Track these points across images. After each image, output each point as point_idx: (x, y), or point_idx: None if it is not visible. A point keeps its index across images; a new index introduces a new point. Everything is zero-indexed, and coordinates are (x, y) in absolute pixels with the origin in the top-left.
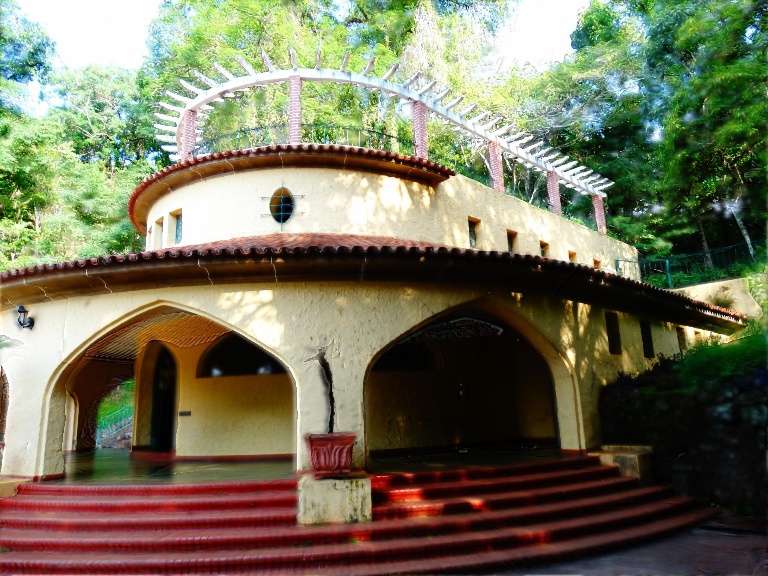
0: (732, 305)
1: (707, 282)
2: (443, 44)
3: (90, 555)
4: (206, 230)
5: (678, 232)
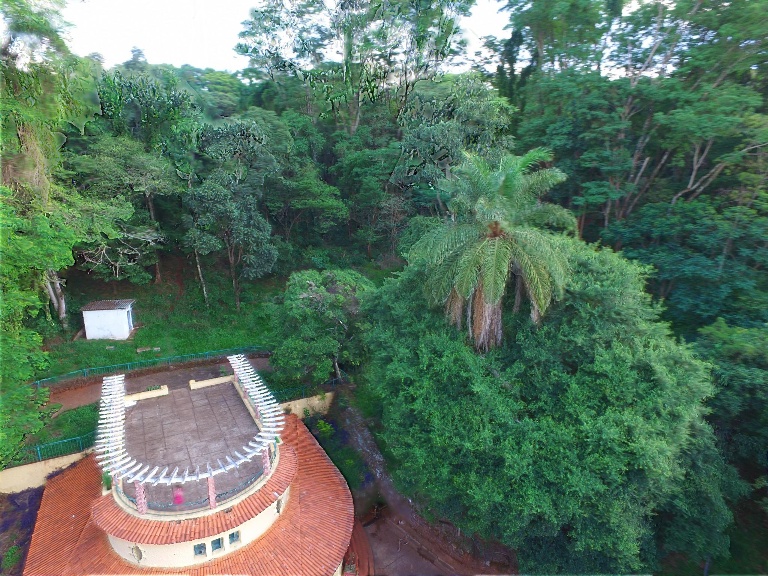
0: (291, 411)
1: (283, 402)
2: None
3: None
4: None
5: (150, 263)
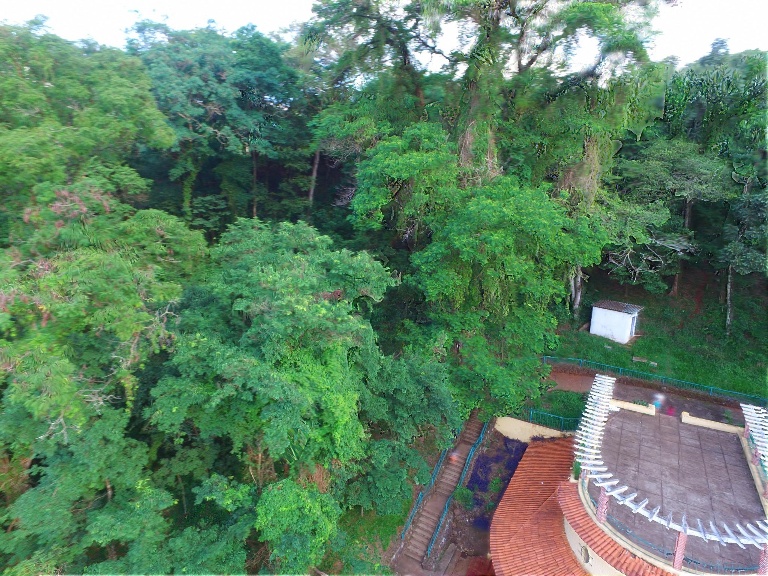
0: None
1: None
2: (597, 162)
3: None
4: None
5: (669, 273)
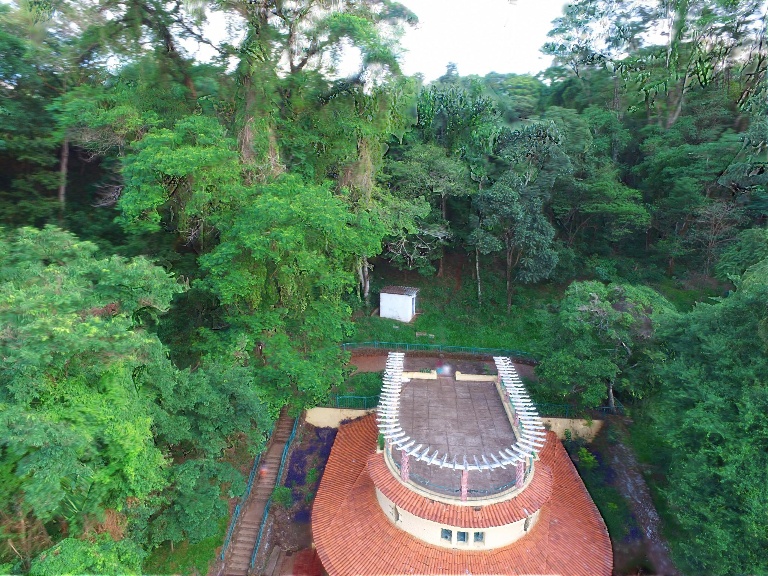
0: (551, 428)
1: (543, 416)
2: None
3: None
4: (500, 542)
5: (436, 257)
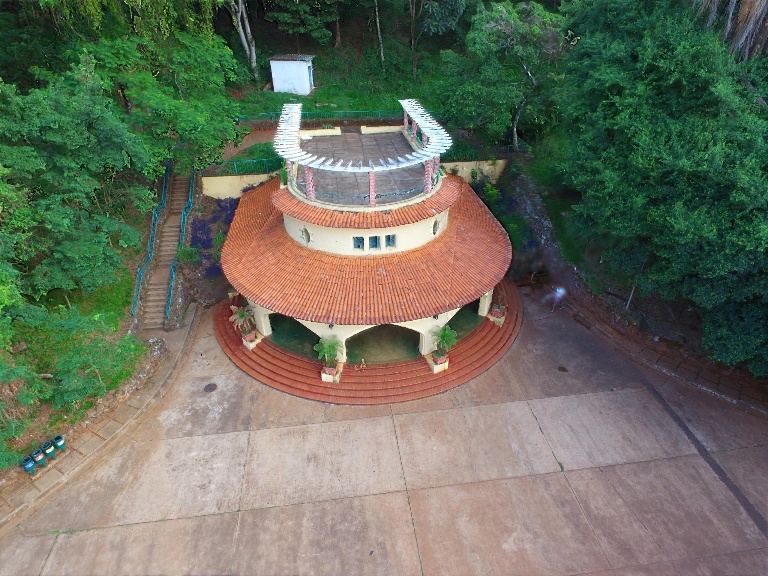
0: None
1: (450, 162)
2: None
3: (488, 354)
4: (410, 244)
5: (331, 19)
